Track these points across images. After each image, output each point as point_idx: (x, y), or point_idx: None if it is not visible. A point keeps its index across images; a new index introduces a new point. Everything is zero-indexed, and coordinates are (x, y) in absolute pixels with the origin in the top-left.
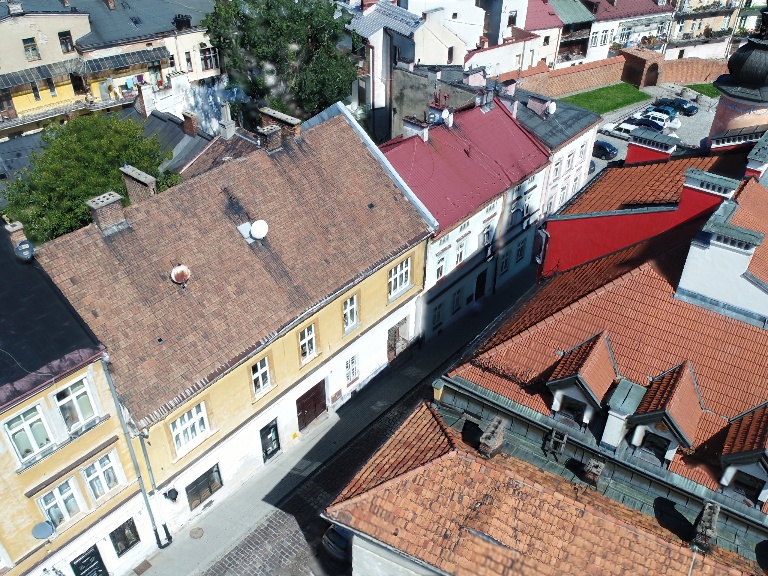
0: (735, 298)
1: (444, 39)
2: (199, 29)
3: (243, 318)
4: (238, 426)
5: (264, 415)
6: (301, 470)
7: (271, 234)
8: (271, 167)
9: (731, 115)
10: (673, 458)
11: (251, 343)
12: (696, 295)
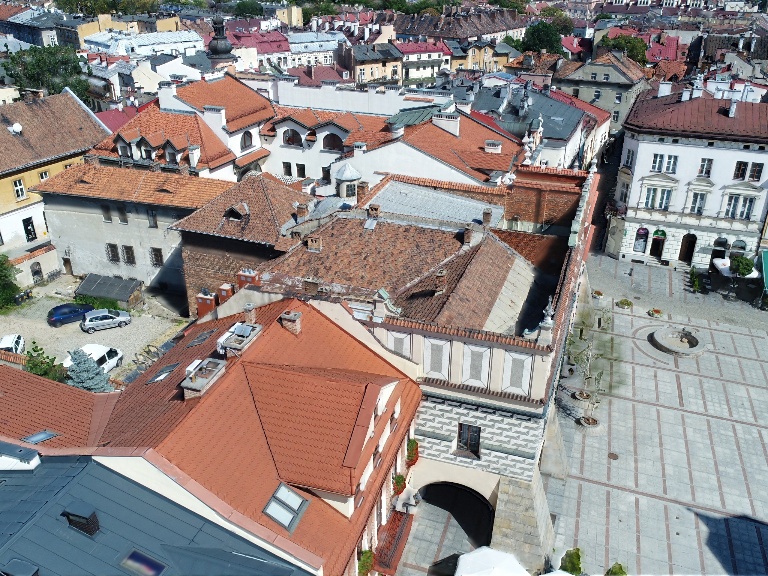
0: (175, 106)
1: (154, 78)
2: (11, 86)
3: (8, 159)
4: (9, 211)
5: (24, 212)
6: (47, 244)
7: (25, 132)
8: (27, 108)
9: (214, 67)
10: (155, 158)
11: (11, 167)
12: (166, 109)
